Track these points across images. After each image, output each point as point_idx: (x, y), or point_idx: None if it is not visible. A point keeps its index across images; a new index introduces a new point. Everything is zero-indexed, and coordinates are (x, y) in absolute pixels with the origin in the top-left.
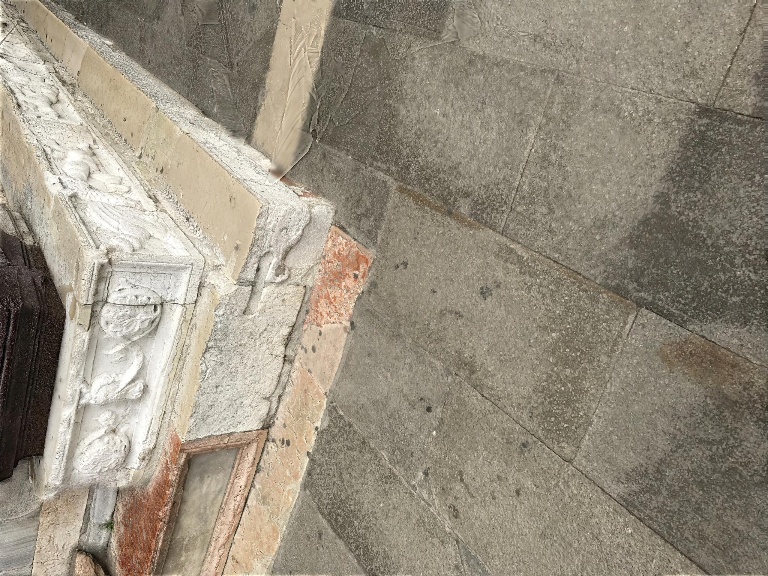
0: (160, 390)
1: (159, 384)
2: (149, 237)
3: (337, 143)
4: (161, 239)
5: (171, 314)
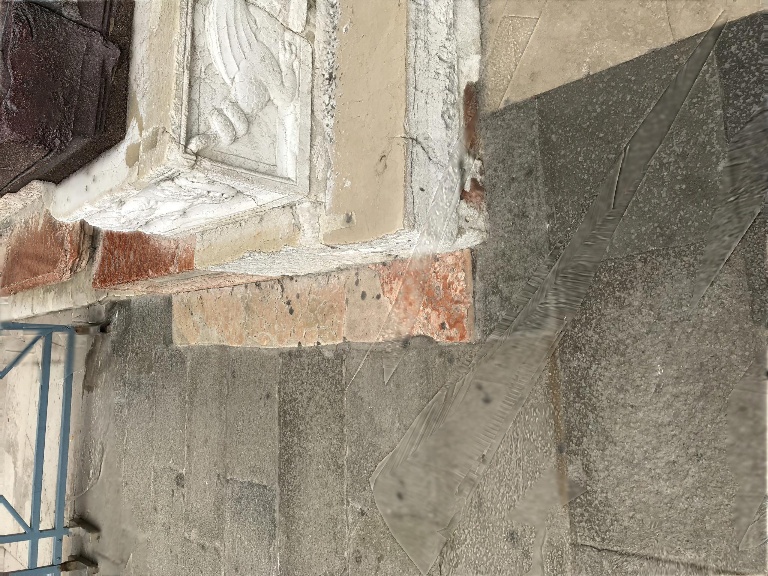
0: (196, 223)
1: (198, 220)
2: (266, 103)
3: (552, 187)
4: (280, 110)
5: (242, 199)
